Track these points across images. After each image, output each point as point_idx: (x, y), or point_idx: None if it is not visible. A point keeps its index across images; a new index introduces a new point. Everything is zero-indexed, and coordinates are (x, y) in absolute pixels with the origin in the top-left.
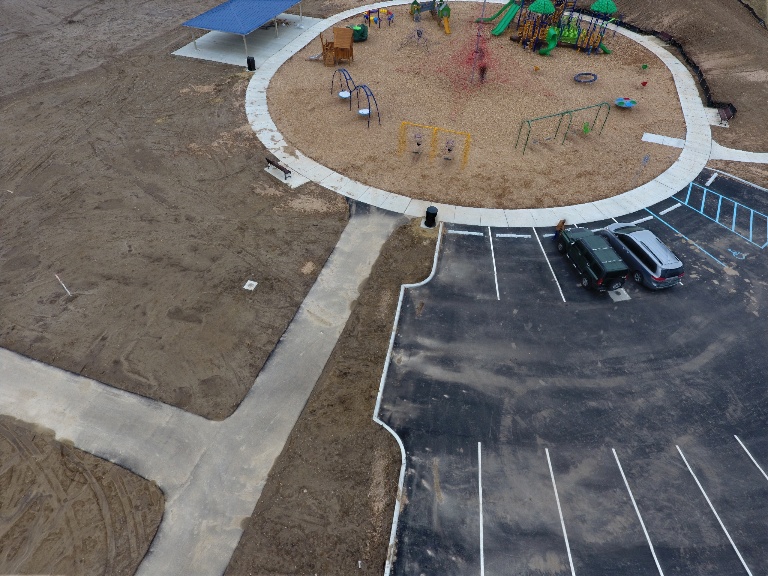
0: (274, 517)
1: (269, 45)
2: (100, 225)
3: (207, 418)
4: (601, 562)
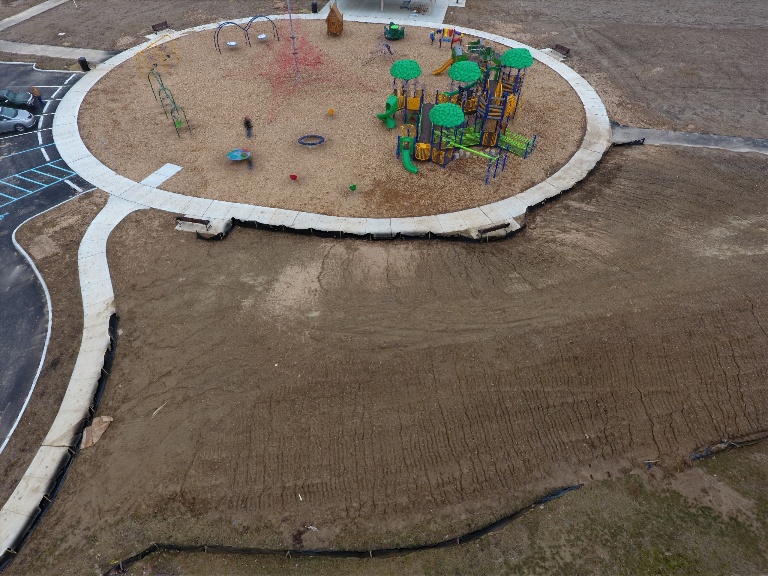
0: None
1: (365, 12)
2: (128, 5)
3: None
4: None
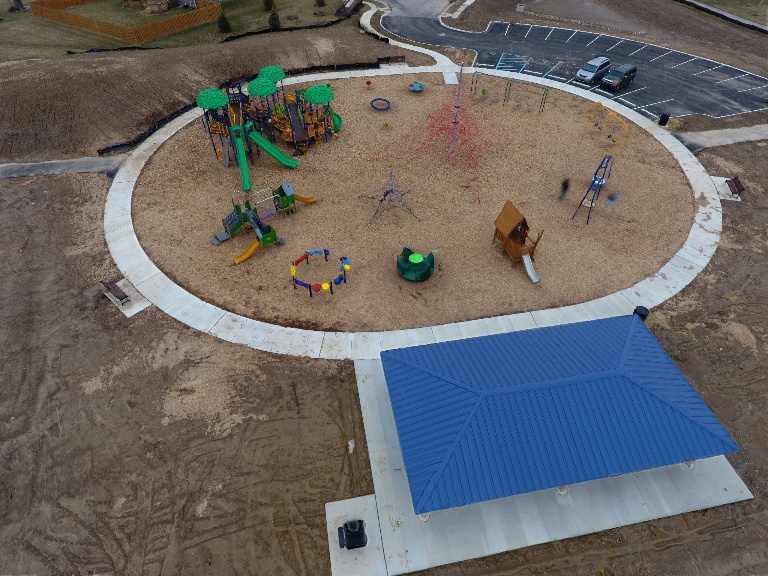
0: None
1: None
2: None
3: None
4: None
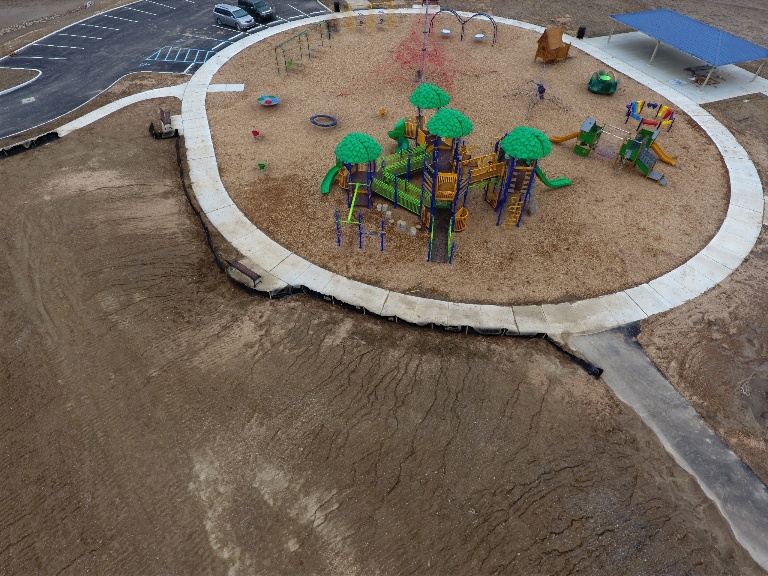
0: None
1: (632, 56)
2: None
3: None
4: None
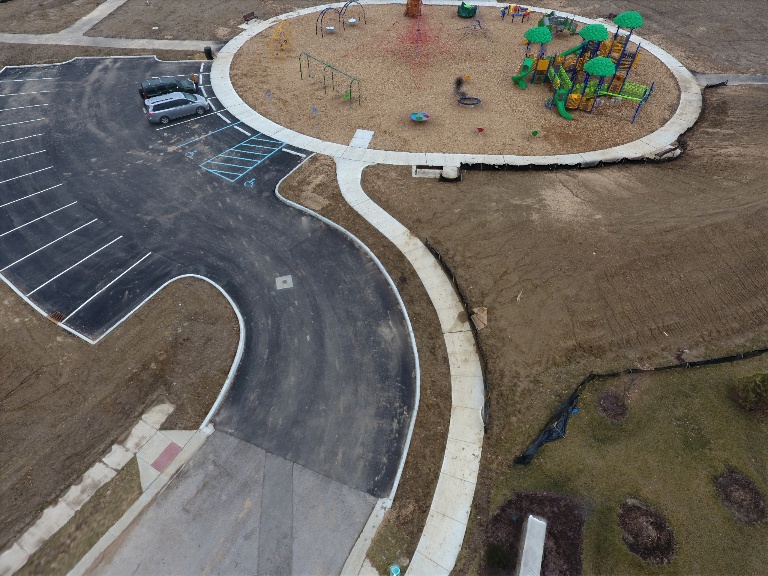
0: (41, 47)
1: None
2: None
3: (84, 33)
4: (2, 100)
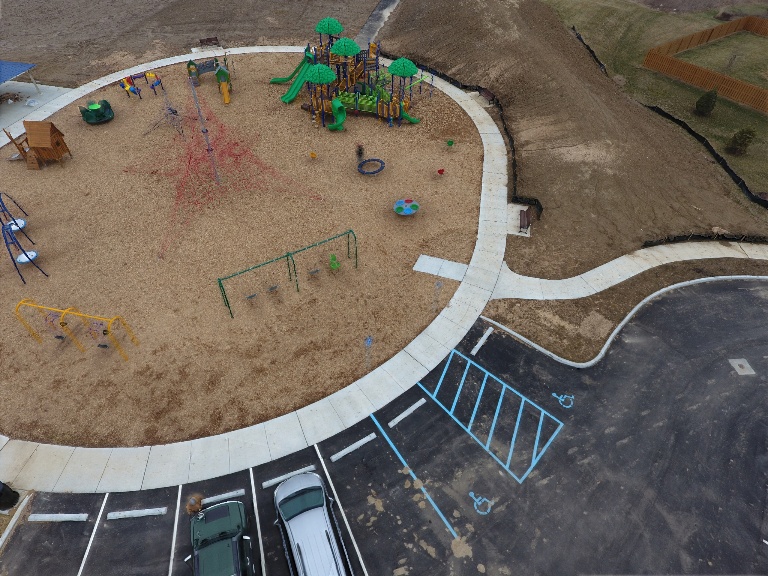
0: None
1: None
2: None
3: None
4: None
